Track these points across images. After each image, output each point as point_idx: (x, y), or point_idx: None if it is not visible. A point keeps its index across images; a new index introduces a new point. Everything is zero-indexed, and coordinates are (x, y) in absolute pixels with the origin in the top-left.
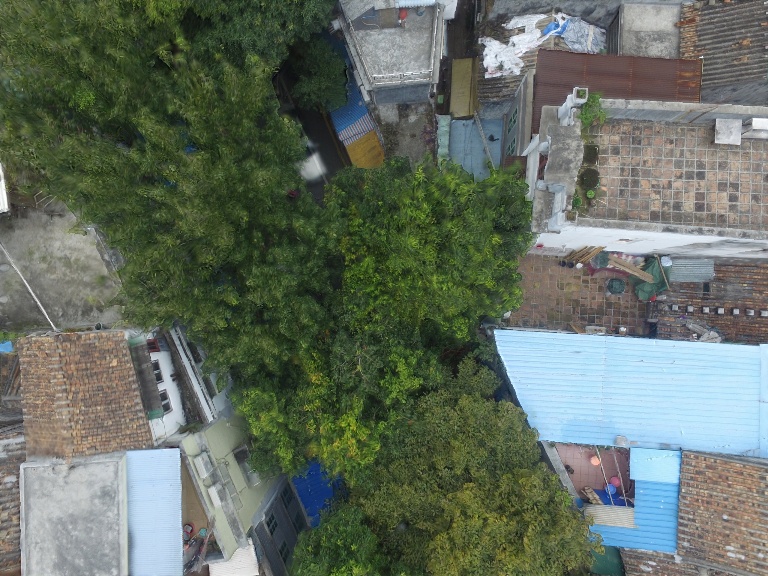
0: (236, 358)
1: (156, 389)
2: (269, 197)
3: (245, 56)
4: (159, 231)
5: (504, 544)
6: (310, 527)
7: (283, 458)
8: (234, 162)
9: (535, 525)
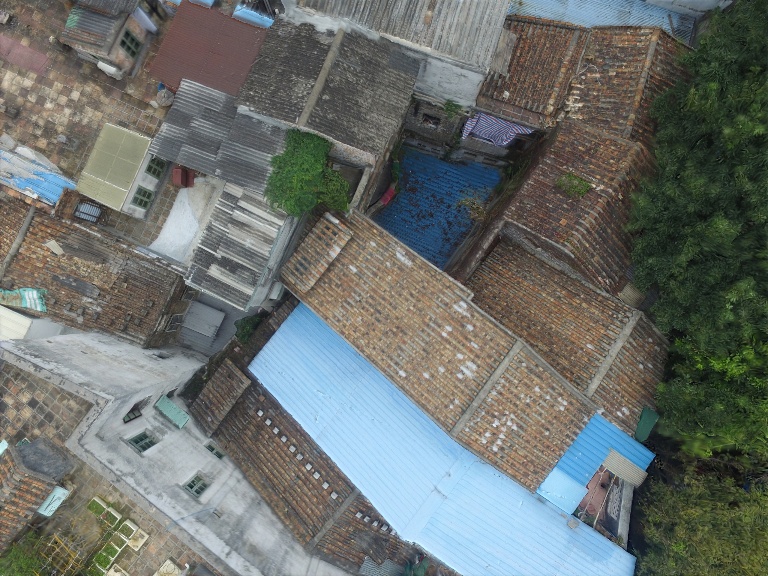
0: None
1: None
2: None
3: None
4: None
5: (766, 556)
6: None
7: None
8: None
9: None
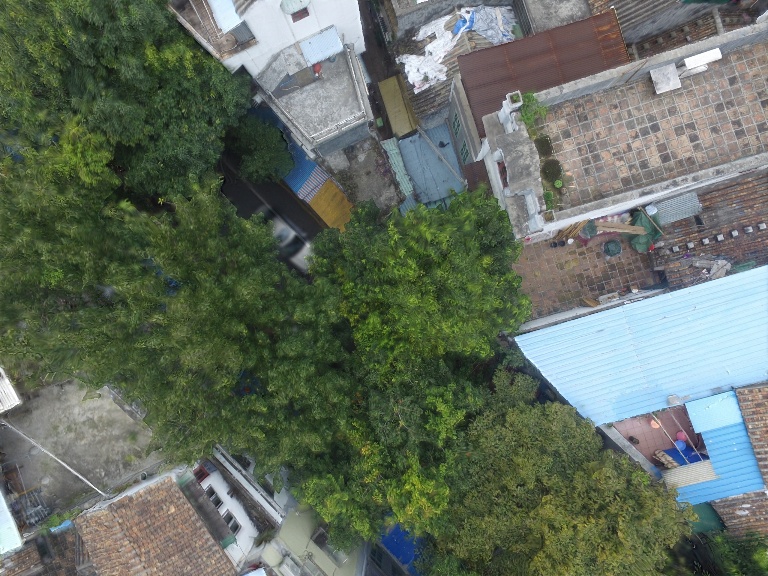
0: (283, 458)
1: (219, 517)
2: (258, 298)
3: (185, 164)
4: (168, 369)
5: (601, 544)
6: (409, 575)
7: (361, 530)
8: (214, 282)
9: (623, 516)
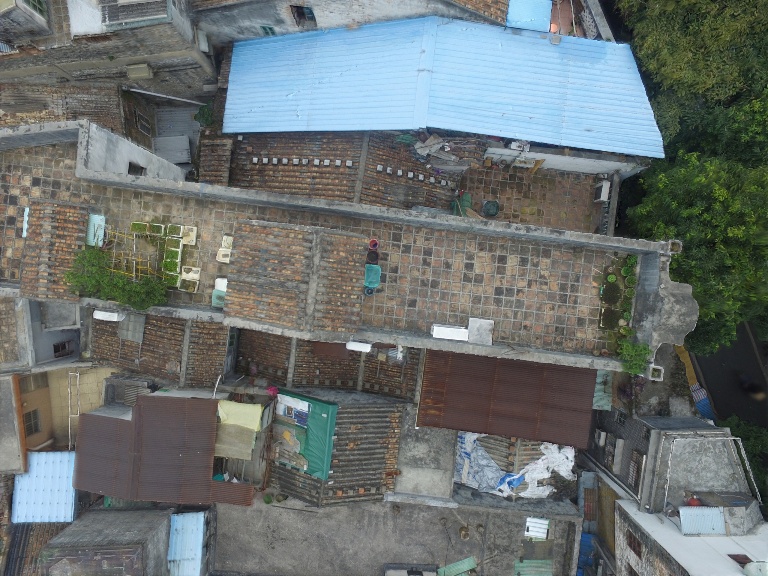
0: None
1: None
2: None
3: None
4: None
5: None
6: None
7: None
8: None
9: None
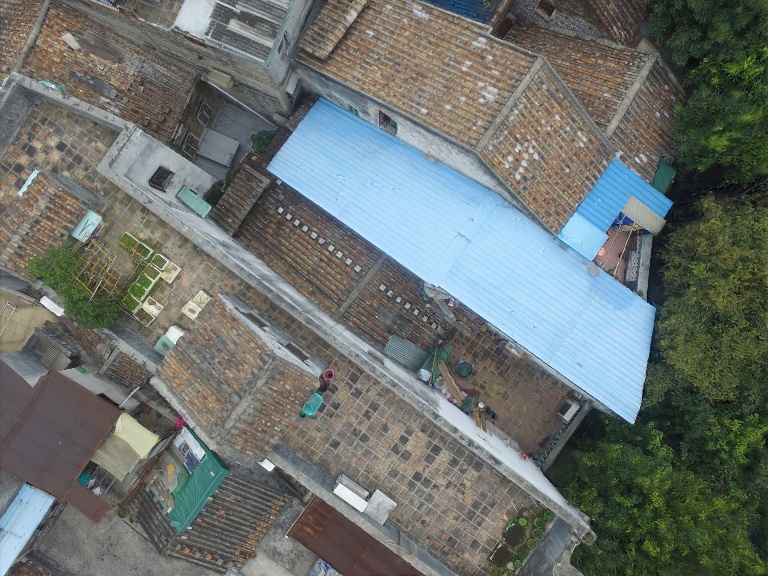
0: None
1: None
2: None
3: None
4: None
5: None
6: None
7: None
8: None
9: None
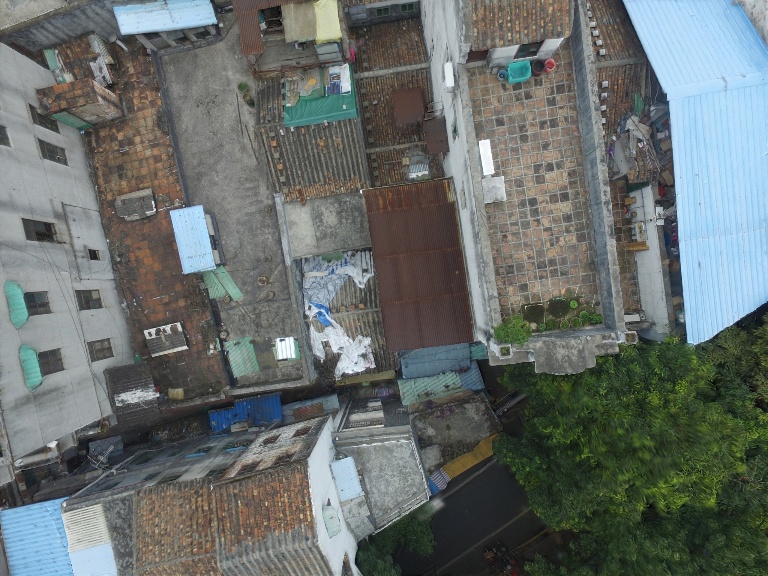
0: None
1: None
2: None
3: None
4: None
5: None
6: None
7: None
8: None
9: None
